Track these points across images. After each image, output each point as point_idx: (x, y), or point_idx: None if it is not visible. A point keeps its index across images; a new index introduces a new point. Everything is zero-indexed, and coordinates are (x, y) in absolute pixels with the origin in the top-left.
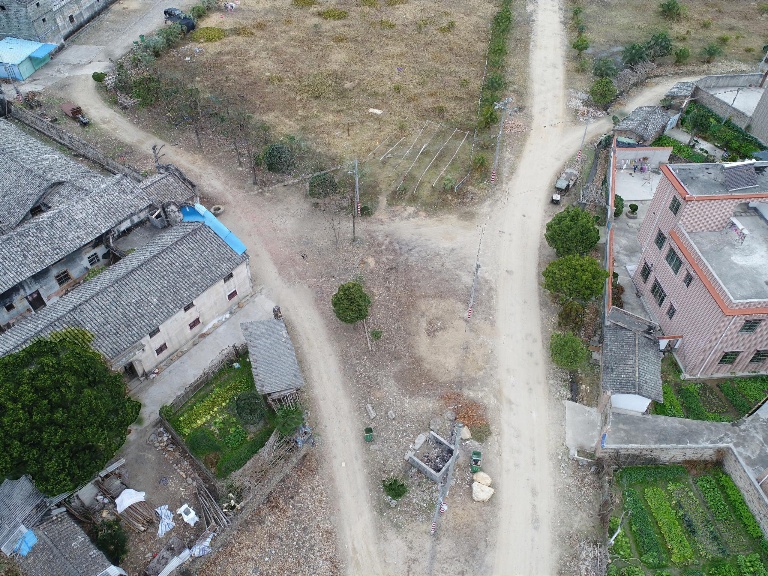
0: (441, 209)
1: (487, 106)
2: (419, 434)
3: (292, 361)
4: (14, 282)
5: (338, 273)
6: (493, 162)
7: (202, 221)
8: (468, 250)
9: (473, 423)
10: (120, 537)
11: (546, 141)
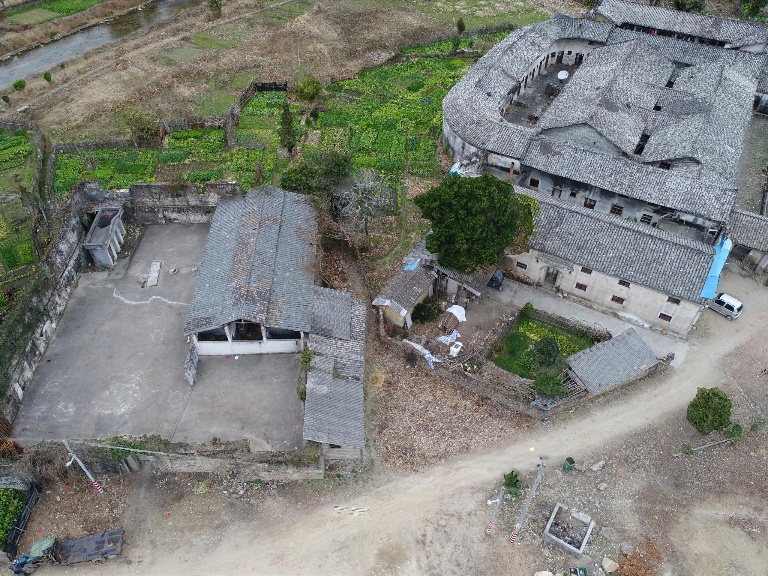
0: None
1: None
2: (590, 516)
3: (615, 379)
4: (587, 181)
5: (764, 408)
6: None
7: (716, 253)
8: None
9: (627, 575)
10: (430, 315)
11: None
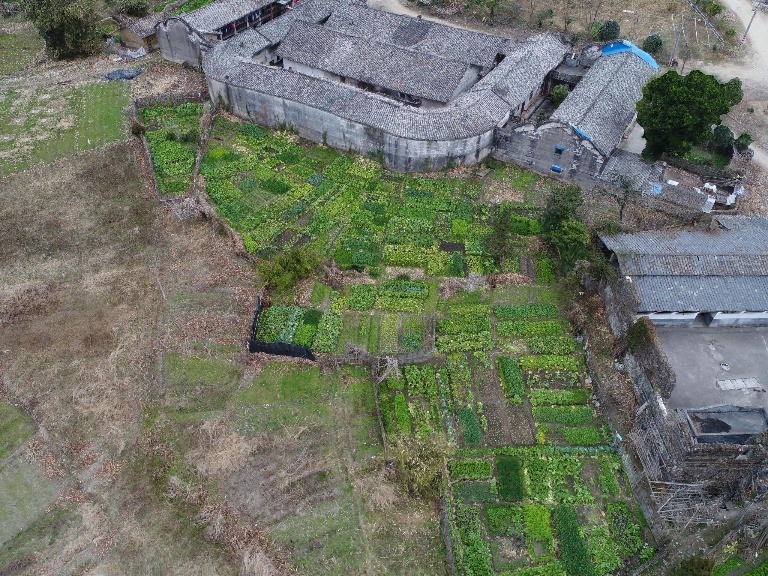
0: (720, 61)
1: (704, 5)
2: None
3: None
4: (532, 87)
5: None
6: (731, 36)
7: (628, 50)
8: (756, 79)
9: None
10: None
11: (756, 24)
